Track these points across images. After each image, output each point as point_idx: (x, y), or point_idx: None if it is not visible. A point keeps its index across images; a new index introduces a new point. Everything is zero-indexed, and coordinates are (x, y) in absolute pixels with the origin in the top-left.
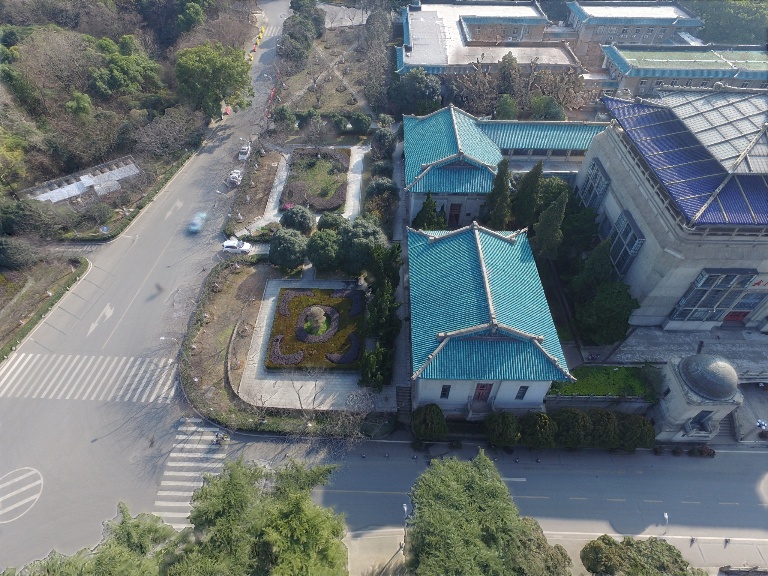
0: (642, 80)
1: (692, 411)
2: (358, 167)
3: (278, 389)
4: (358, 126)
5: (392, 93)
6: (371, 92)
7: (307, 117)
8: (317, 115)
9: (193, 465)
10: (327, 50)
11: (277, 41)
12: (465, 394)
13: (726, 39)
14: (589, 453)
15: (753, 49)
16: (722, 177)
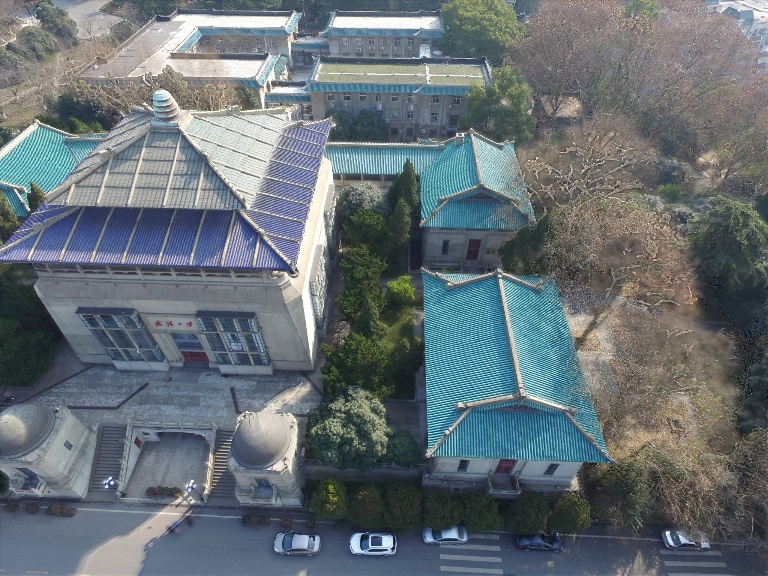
0: (328, 95)
1: (1, 468)
2: None
3: None
4: (6, 141)
5: (57, 107)
6: (35, 106)
7: None
8: None
9: None
10: (67, 61)
11: None
12: None
13: None
14: None
15: (470, 62)
16: (72, 208)
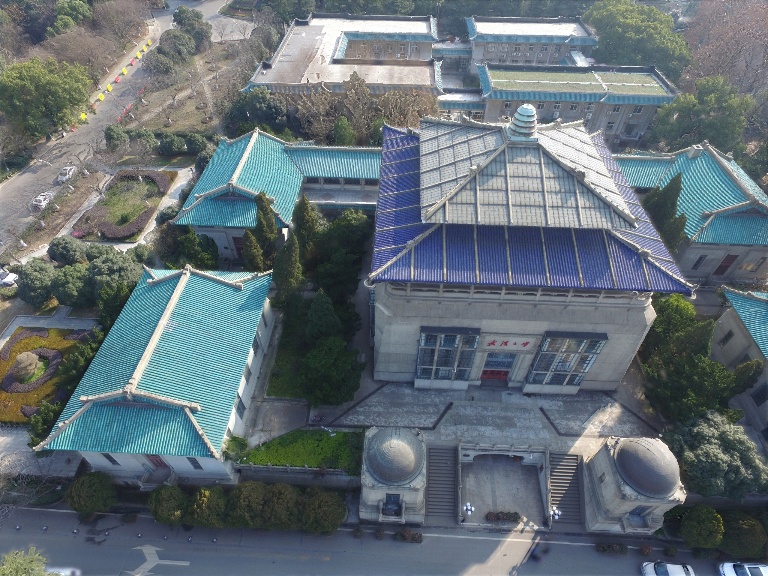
0: (506, 102)
1: (374, 493)
2: (178, 191)
3: None
4: (190, 147)
5: (235, 113)
6: (213, 111)
7: (135, 137)
8: (148, 135)
9: None
10: (207, 65)
11: (142, 56)
12: (134, 462)
13: (615, 59)
14: (278, 533)
15: (638, 70)
16: (430, 225)
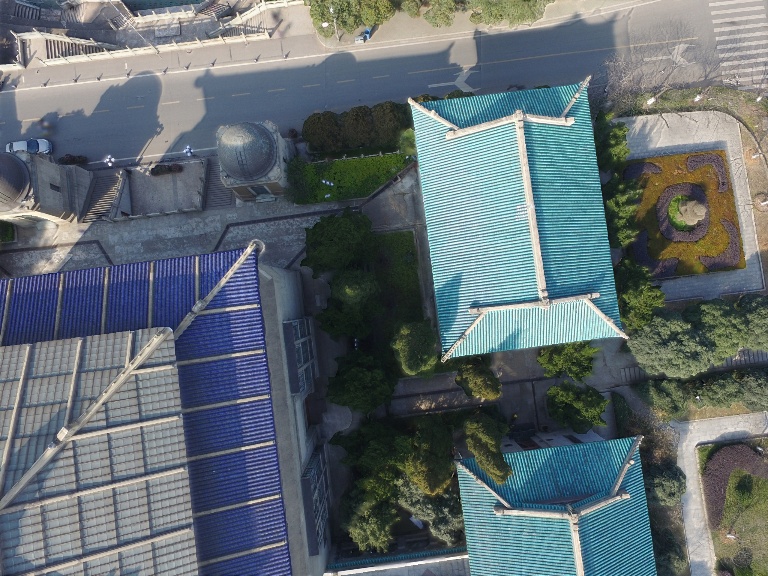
0: None
1: None
2: None
3: (697, 132)
4: None
5: None
6: None
7: None
8: None
9: (748, 52)
10: None
11: None
12: None
13: None
14: None
15: None
16: None
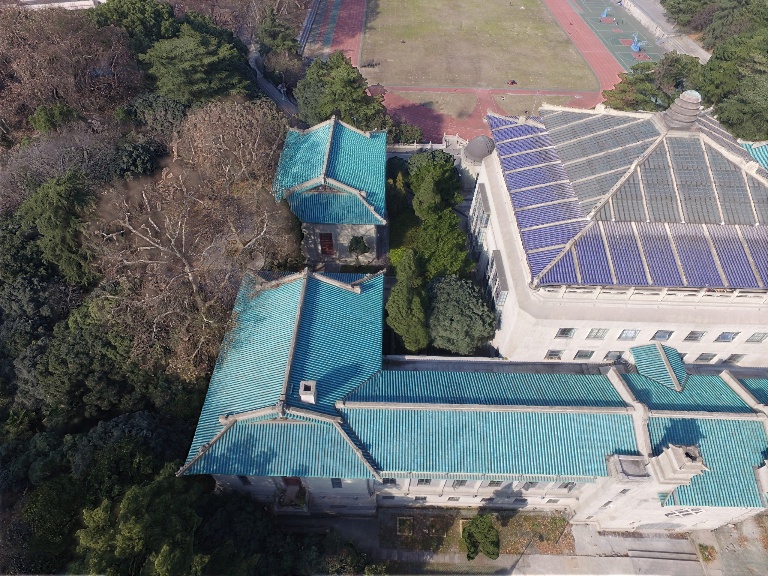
0: None
1: None
2: None
3: None
4: None
5: None
6: None
7: None
8: None
9: None
10: None
11: None
12: None
13: None
14: None
15: None
16: None
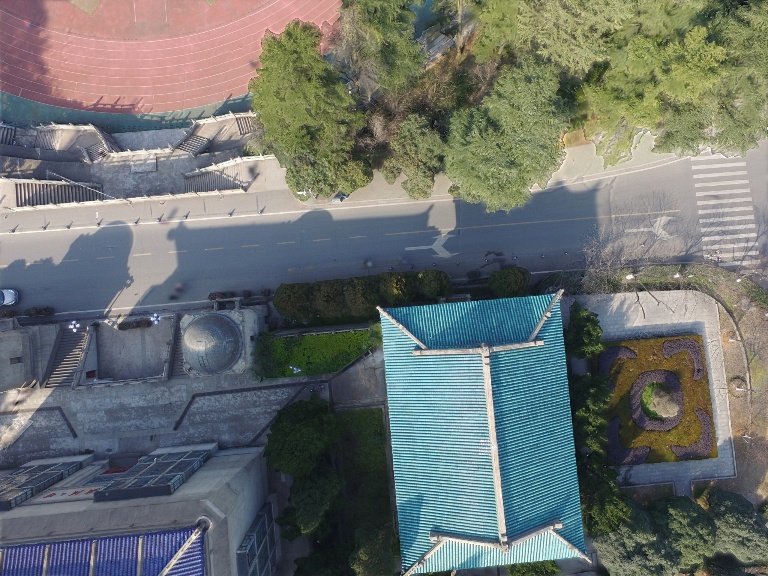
0: None
1: None
2: None
3: (675, 312)
4: None
5: None
6: None
7: None
8: None
9: (730, 227)
10: None
11: None
12: None
13: None
14: None
15: None
16: None
